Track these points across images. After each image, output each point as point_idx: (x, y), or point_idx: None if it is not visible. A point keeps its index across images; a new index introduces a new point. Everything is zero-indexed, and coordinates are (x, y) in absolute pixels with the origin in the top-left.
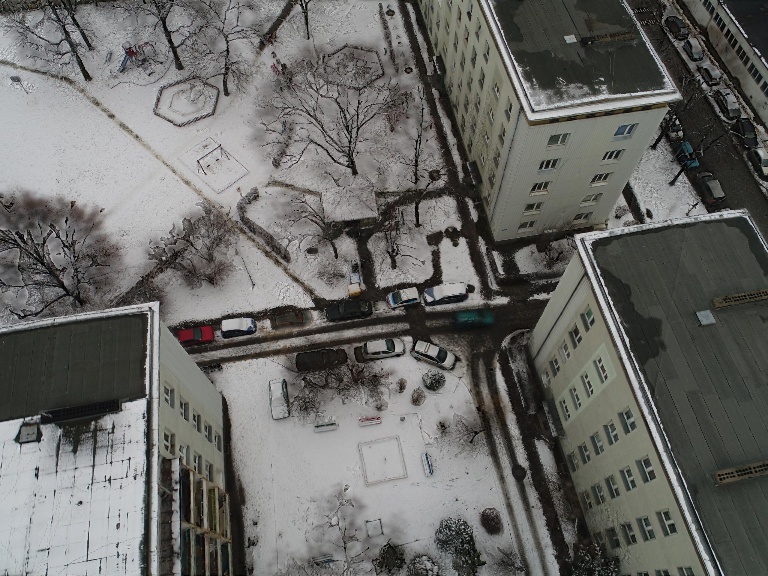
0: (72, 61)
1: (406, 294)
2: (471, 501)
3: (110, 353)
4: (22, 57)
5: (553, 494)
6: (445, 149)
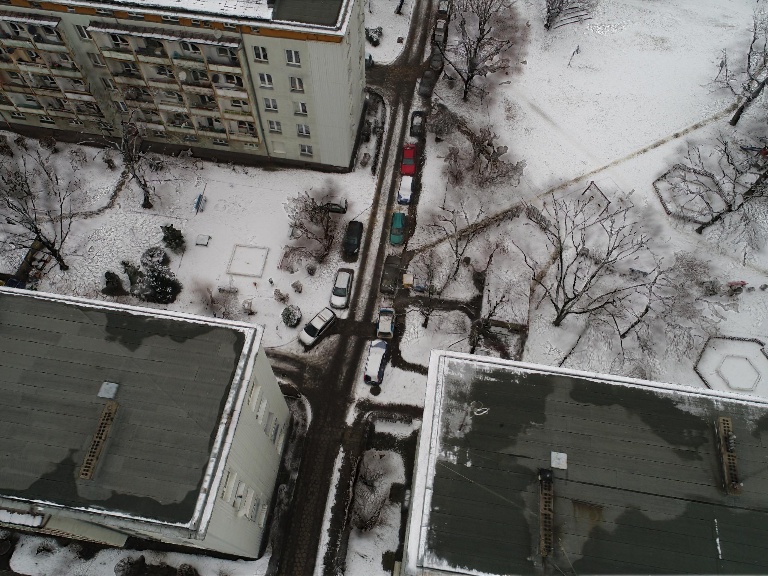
0: (760, 112)
1: (386, 321)
2: None
3: (313, 7)
4: None
5: None
6: None
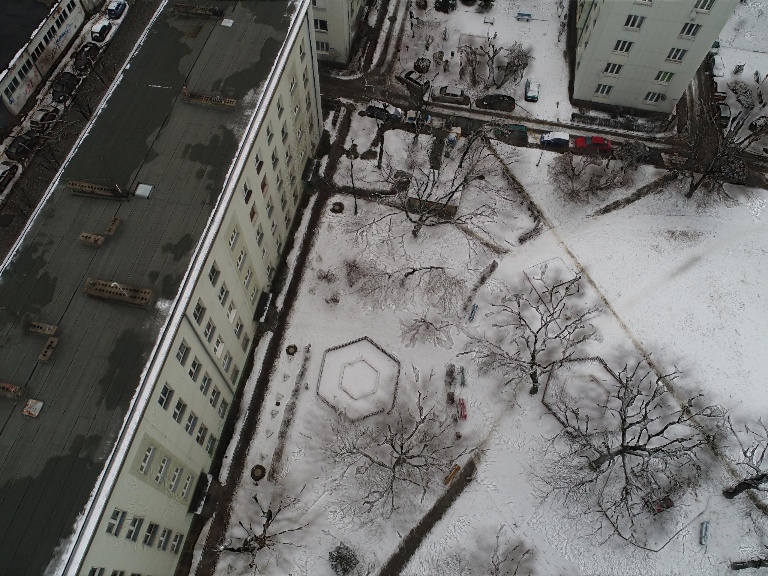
0: (761, 542)
1: None
2: None
3: None
4: None
5: (380, 5)
6: (312, 231)
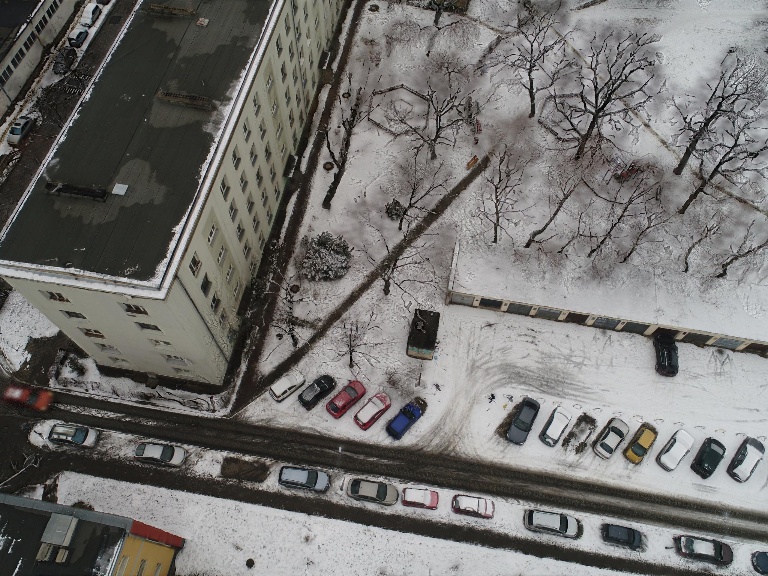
0: None
1: None
2: None
3: None
4: (763, 224)
5: None
6: (355, 23)
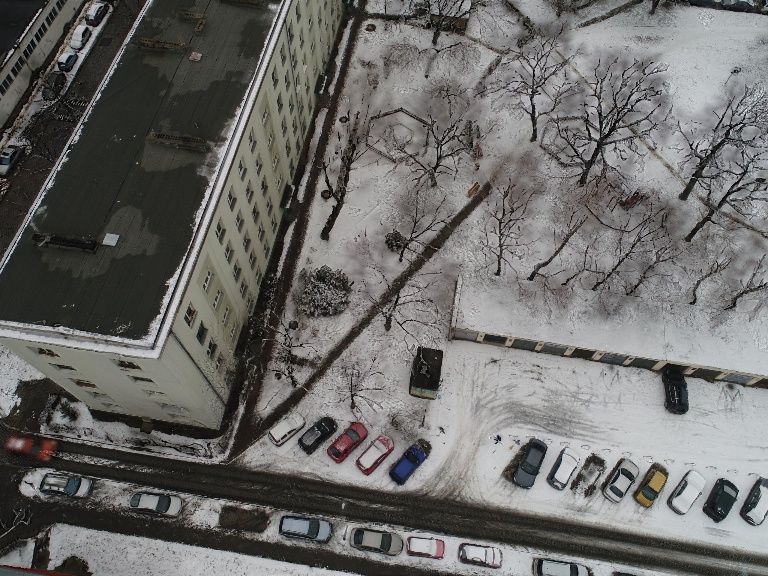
0: None
1: None
2: None
3: None
4: None
5: None
6: (352, 43)
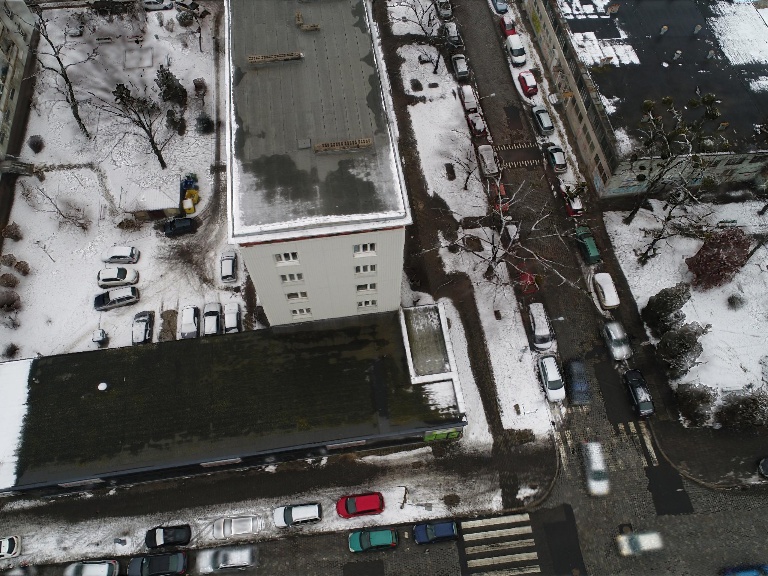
0: None
1: None
2: (192, 80)
3: None
4: None
5: None
6: None
